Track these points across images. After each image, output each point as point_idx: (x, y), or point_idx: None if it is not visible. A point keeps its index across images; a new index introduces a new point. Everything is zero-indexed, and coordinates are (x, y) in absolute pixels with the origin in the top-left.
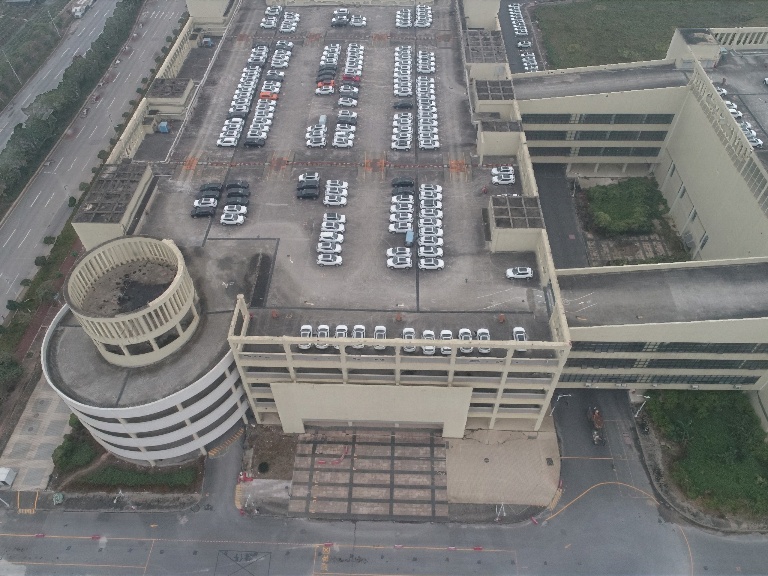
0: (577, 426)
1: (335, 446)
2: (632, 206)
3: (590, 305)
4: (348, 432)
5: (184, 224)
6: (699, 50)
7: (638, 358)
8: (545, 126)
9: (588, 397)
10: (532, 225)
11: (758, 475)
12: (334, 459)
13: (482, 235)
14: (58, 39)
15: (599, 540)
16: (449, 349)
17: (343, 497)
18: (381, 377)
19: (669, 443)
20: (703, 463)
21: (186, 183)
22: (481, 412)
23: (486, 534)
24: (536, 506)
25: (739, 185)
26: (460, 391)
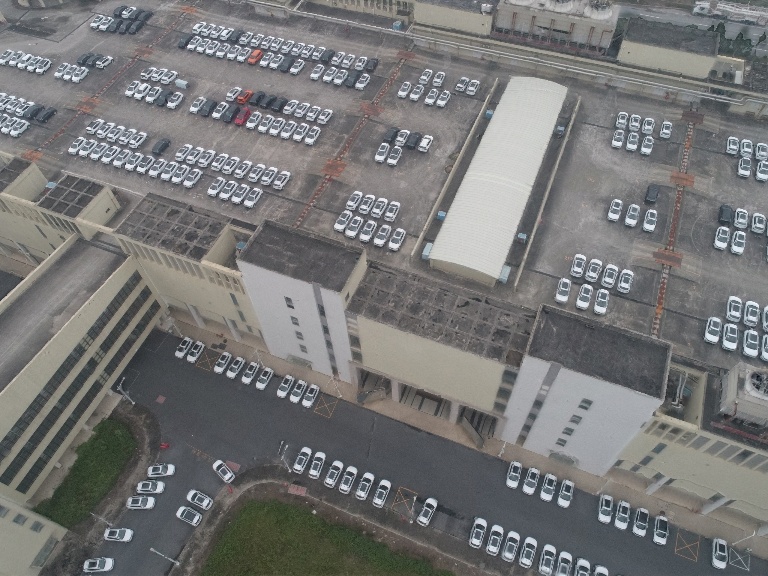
0: None
1: None
2: None
3: None
4: None
5: (121, 5)
6: None
7: None
8: None
9: None
10: None
11: None
12: None
13: None
14: (633, 1)
15: None
16: None
17: None
18: None
19: None
20: None
21: (168, 8)
22: None
23: None
24: None
25: None
26: None
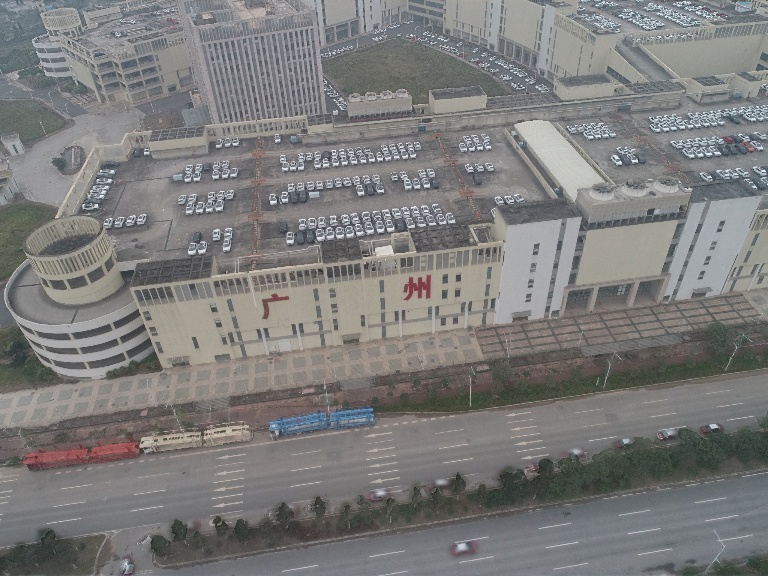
0: None
1: None
2: None
3: None
4: None
5: None
6: None
7: None
8: None
9: None
10: None
11: None
12: None
13: None
14: None
15: None
16: None
17: None
18: None
19: None
20: None
21: None
22: None
23: None
24: None
25: None
26: None
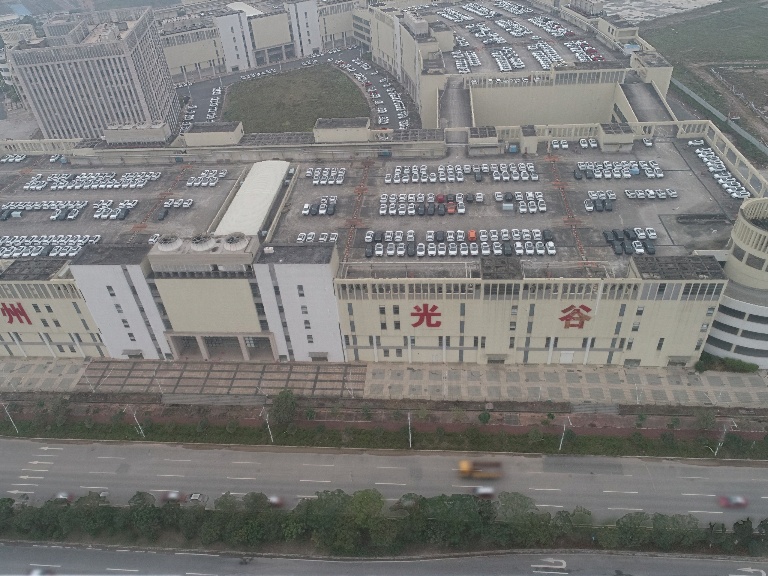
0: None
1: None
2: None
3: (661, 128)
4: None
5: None
6: None
7: None
8: None
9: None
10: None
11: None
12: None
13: (617, 153)
14: None
15: None
16: None
17: None
18: None
19: None
20: None
21: (613, 264)
22: None
23: None
24: None
25: (557, 89)
26: None
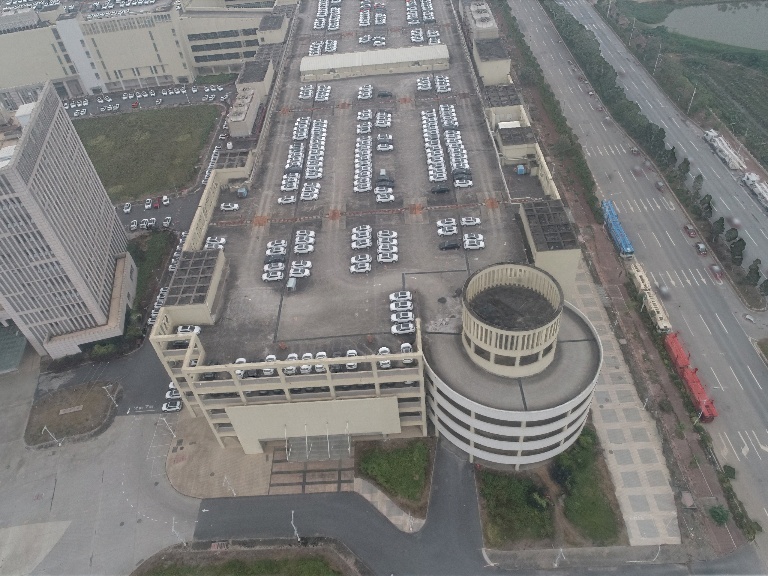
0: None
1: None
2: None
3: None
4: None
5: None
6: None
7: None
8: None
9: None
10: None
11: None
12: None
13: None
14: None
15: None
16: None
17: None
18: None
19: None
20: None
21: None
22: None
23: None
24: None
25: None
26: None
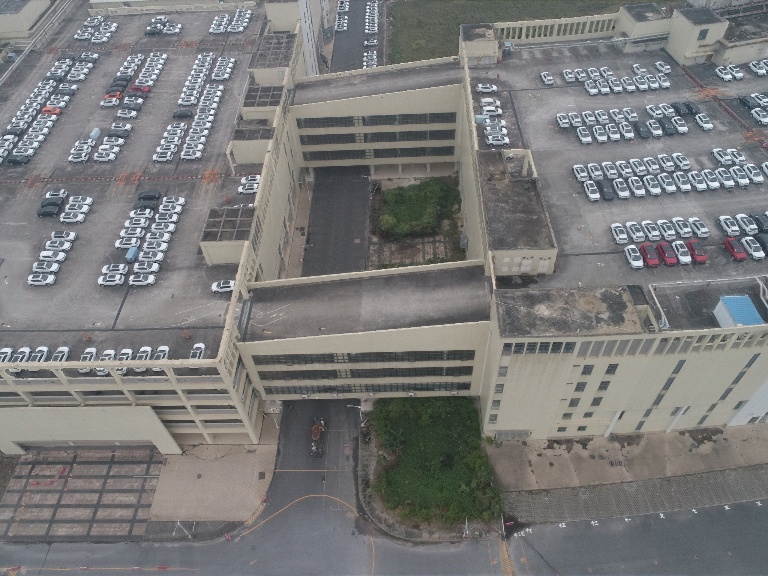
0: (301, 438)
1: (53, 466)
2: (425, 207)
3: (281, 317)
4: (69, 452)
5: None
6: (476, 46)
7: (336, 369)
8: (331, 130)
9: (316, 407)
10: (238, 237)
11: (462, 483)
12: (48, 480)
13: None
14: None
15: (286, 555)
16: (120, 369)
17: (45, 519)
18: (65, 398)
19: (387, 452)
20: (411, 472)
21: None
22: (190, 428)
23: (176, 552)
24: (234, 522)
25: (474, 186)
26: (139, 410)
